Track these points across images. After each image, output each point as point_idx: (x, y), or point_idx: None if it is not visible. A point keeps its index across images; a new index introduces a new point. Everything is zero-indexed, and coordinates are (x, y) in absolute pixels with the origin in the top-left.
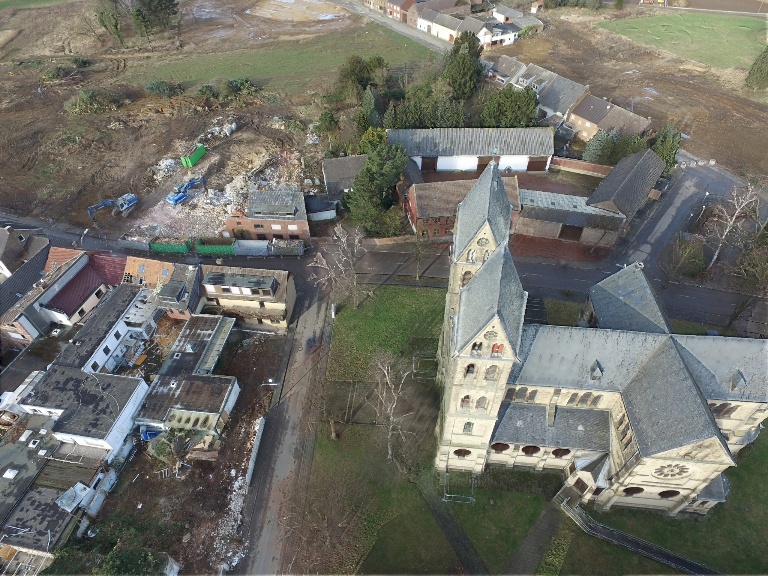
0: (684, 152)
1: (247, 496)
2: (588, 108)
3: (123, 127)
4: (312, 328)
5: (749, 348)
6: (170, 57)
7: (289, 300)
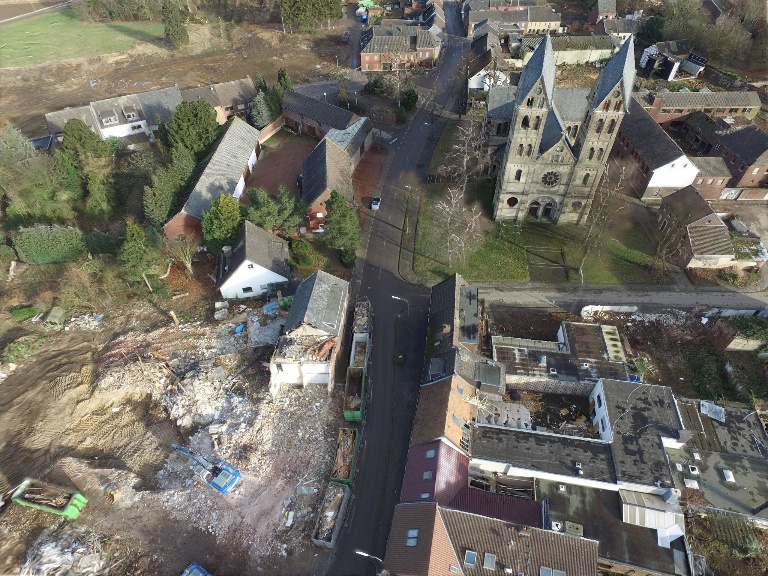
0: None
1: None
2: None
3: None
4: None
5: None
6: None
7: None
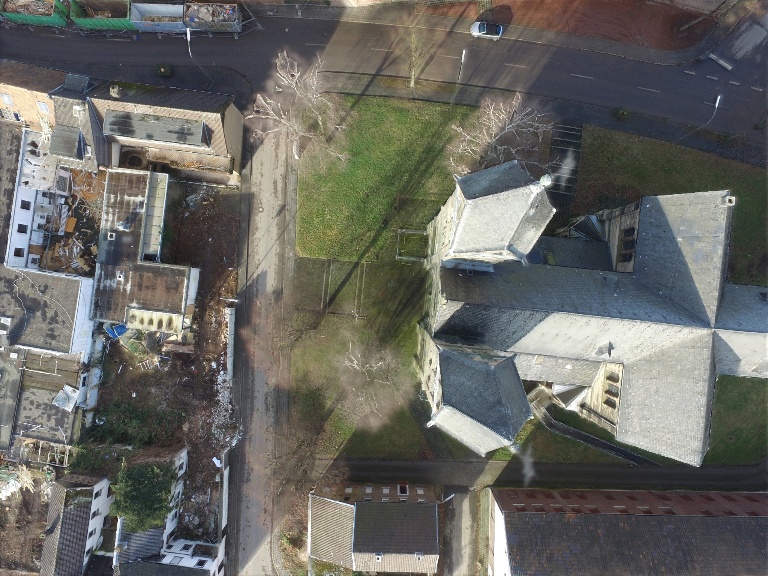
0: None
1: (232, 387)
2: None
3: None
4: (271, 176)
5: None
6: None
7: (233, 140)
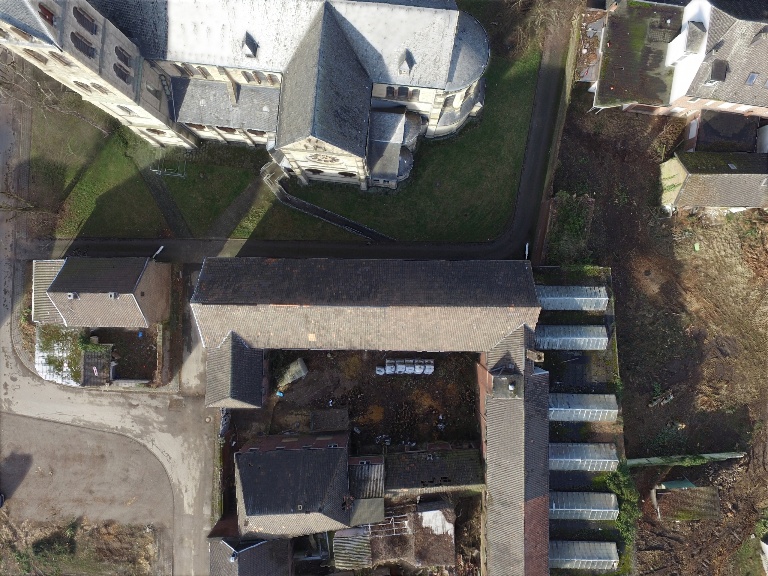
0: None
1: None
2: None
3: None
4: None
5: (419, 21)
6: None
7: None
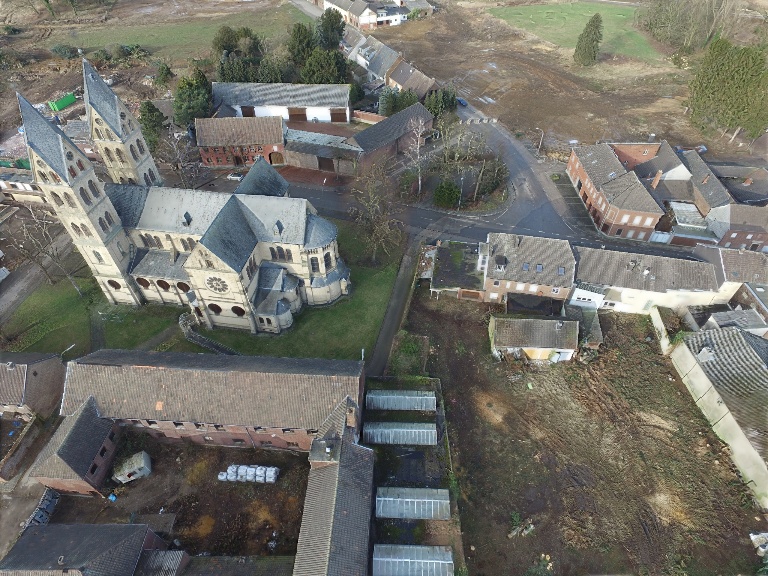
0: (479, 113)
1: None
2: (399, 72)
3: (19, 80)
4: None
5: (285, 204)
6: (92, 28)
7: None
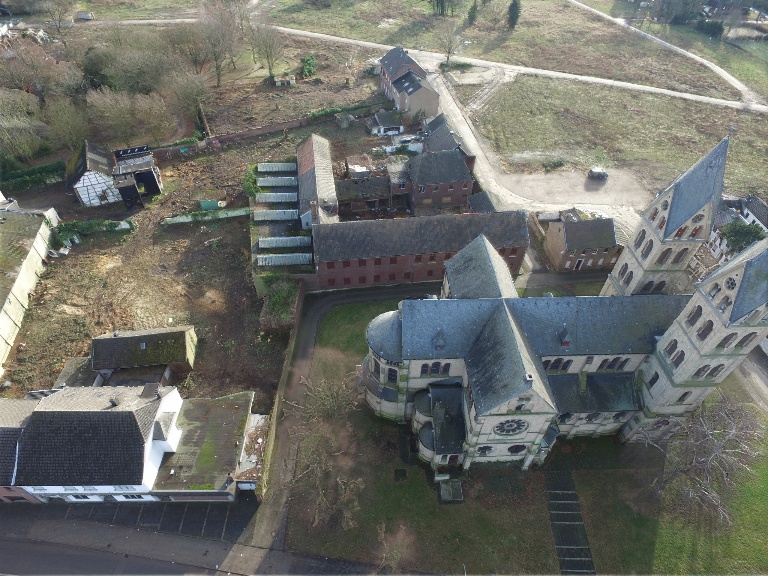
0: None
1: None
2: None
3: None
4: None
5: None
6: None
7: None
